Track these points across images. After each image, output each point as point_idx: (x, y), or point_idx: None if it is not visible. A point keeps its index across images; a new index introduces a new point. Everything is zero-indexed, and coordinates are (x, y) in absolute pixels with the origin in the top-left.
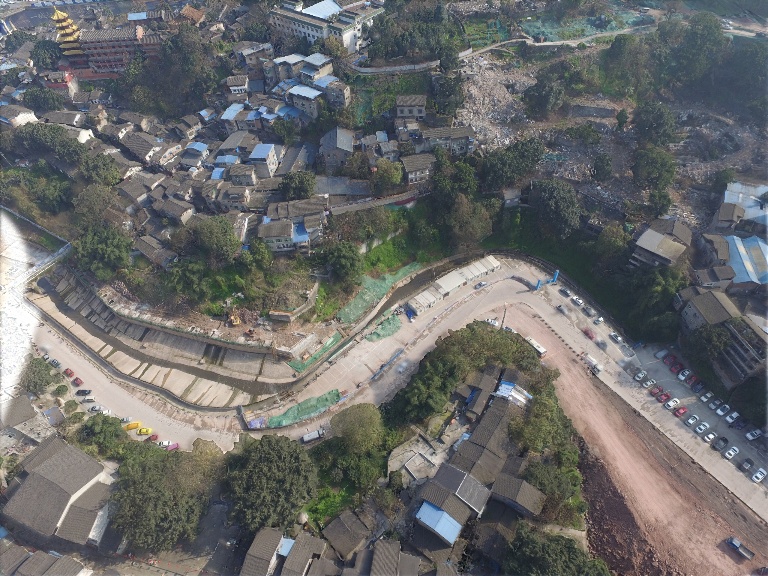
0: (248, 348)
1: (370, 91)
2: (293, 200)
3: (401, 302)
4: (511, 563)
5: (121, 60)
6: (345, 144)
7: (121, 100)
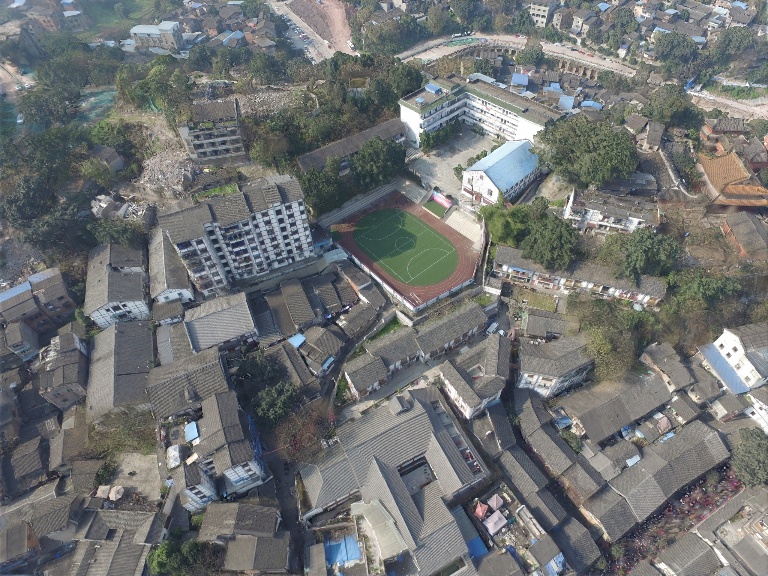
0: None
1: None
2: None
3: None
4: None
5: None
6: None
7: None
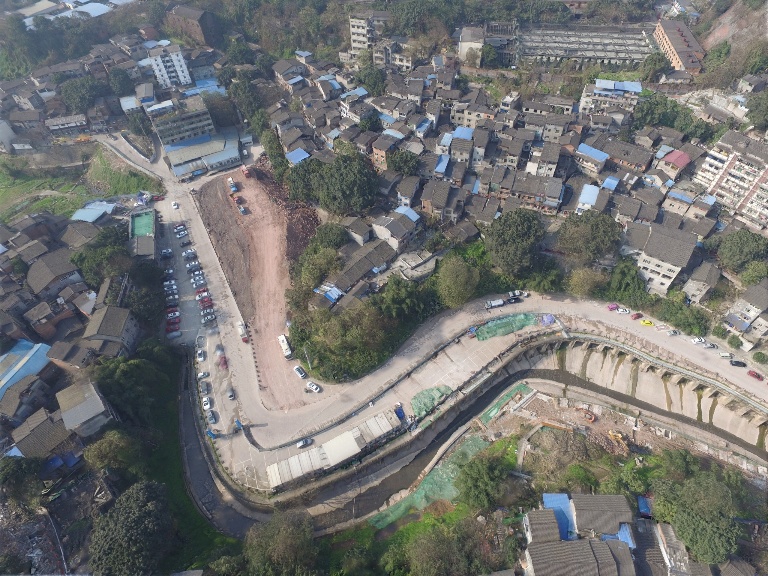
0: None
1: None
2: None
3: (408, 438)
4: None
5: None
6: None
7: None
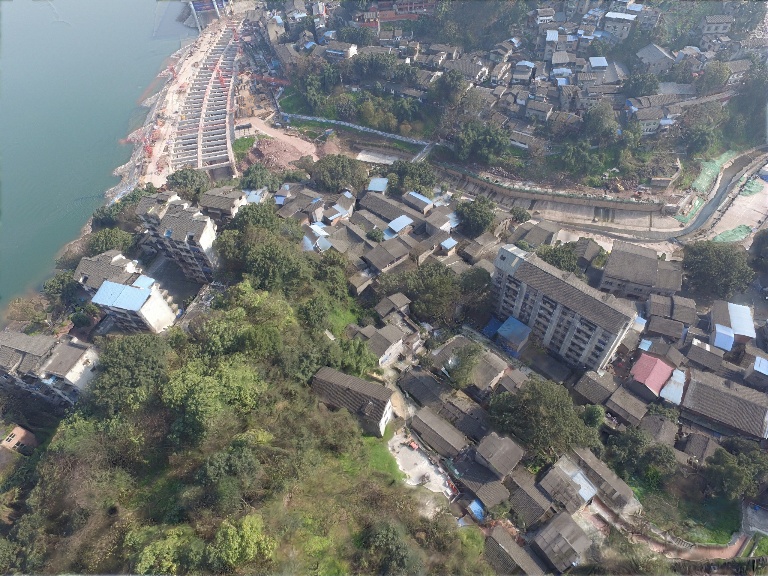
0: (640, 206)
1: (675, 14)
2: (645, 96)
3: (748, 172)
4: None
5: (422, 2)
6: (667, 55)
7: (420, 37)
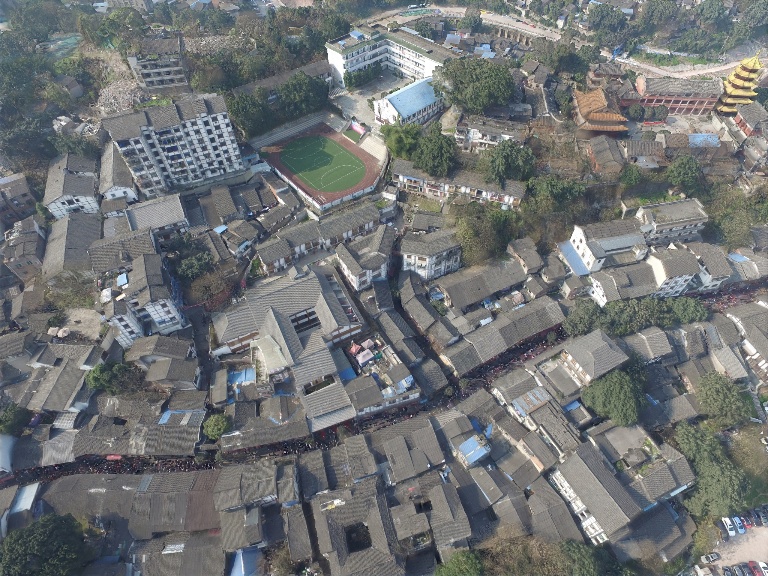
0: None
1: None
2: None
3: None
4: None
5: None
6: None
7: None
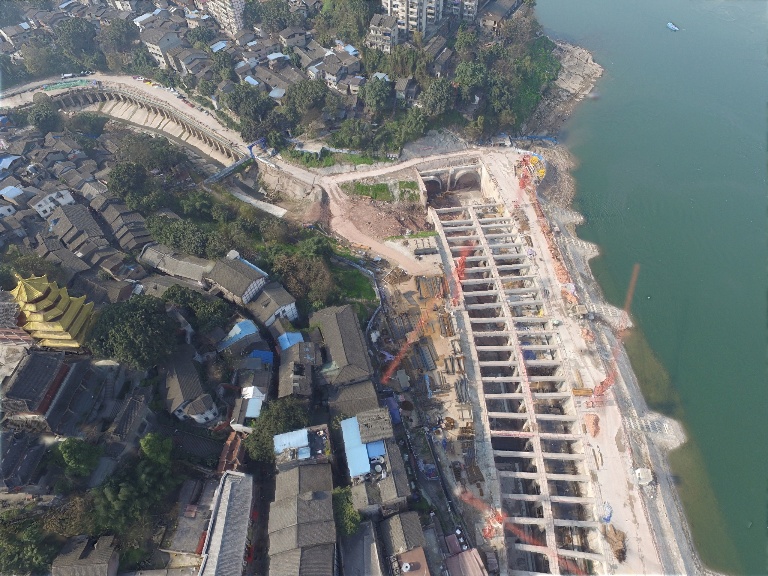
0: None
1: None
2: None
3: None
4: (5, 6)
5: None
6: None
7: None
